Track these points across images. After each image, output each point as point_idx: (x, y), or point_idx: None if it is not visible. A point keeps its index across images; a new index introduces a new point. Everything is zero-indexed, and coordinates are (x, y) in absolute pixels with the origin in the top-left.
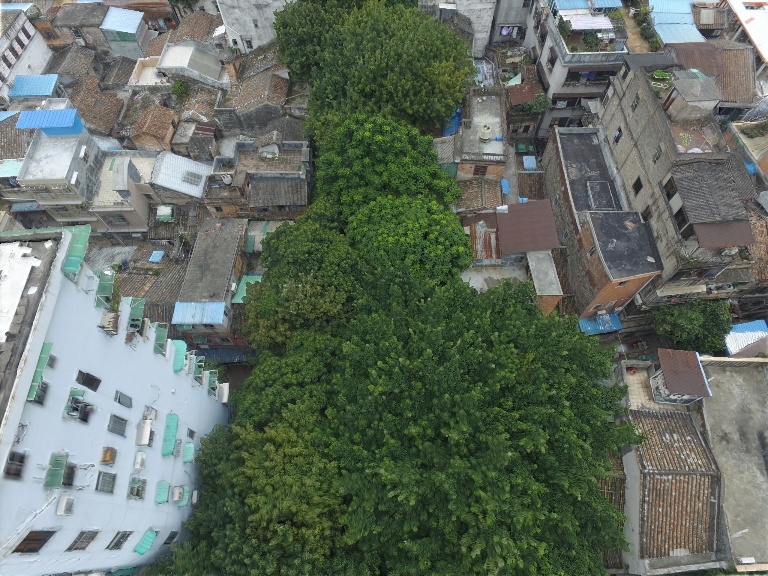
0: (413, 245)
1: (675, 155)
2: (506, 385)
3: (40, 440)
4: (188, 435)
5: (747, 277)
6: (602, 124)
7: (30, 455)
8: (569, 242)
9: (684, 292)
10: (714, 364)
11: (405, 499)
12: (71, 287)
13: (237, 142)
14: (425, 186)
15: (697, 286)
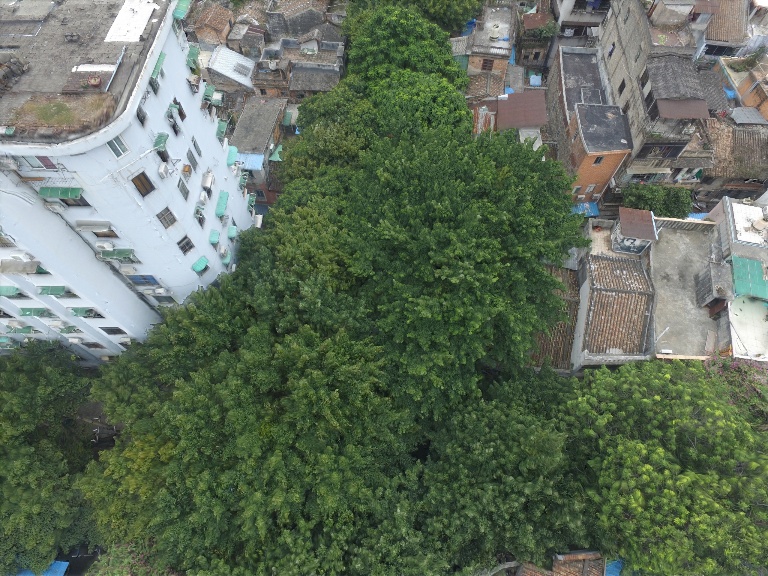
0: (423, 104)
1: (650, 48)
2: (484, 190)
3: (153, 116)
4: (232, 223)
5: (706, 164)
6: (601, 45)
7: (148, 119)
8: (560, 138)
9: (650, 172)
10: (667, 226)
11: (396, 241)
12: (175, 37)
13: (283, 39)
14: (439, 71)
15: (662, 169)
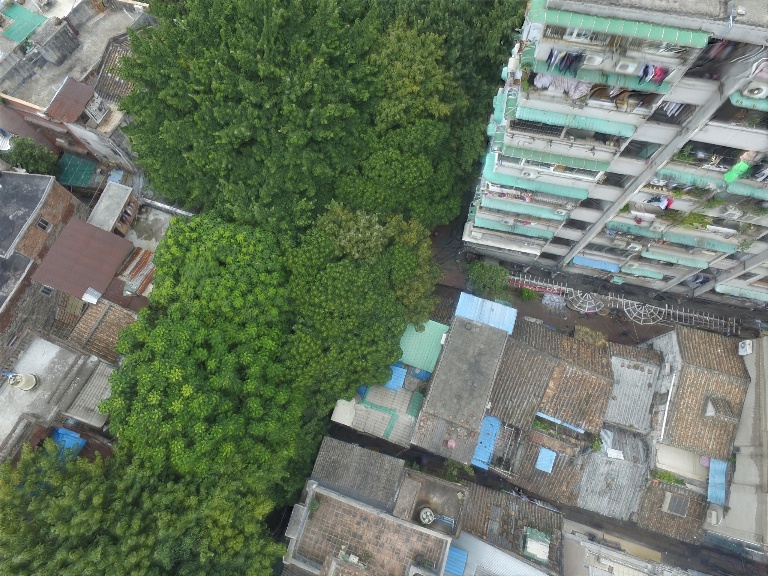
0: None
1: None
2: None
3: None
4: None
5: None
6: None
7: None
8: None
9: None
10: None
11: None
12: None
13: None
14: None
15: None
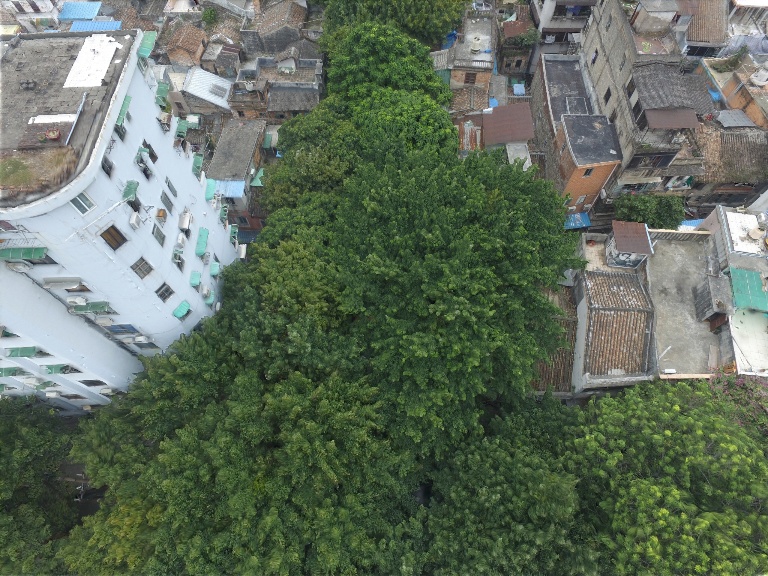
0: (407, 124)
1: (635, 57)
2: (475, 215)
3: (121, 164)
4: (214, 259)
5: (697, 171)
6: (583, 52)
7: (115, 169)
8: (547, 149)
9: (641, 182)
10: (661, 237)
11: (387, 276)
12: (141, 76)
13: (259, 58)
14: (421, 87)
15: (653, 178)
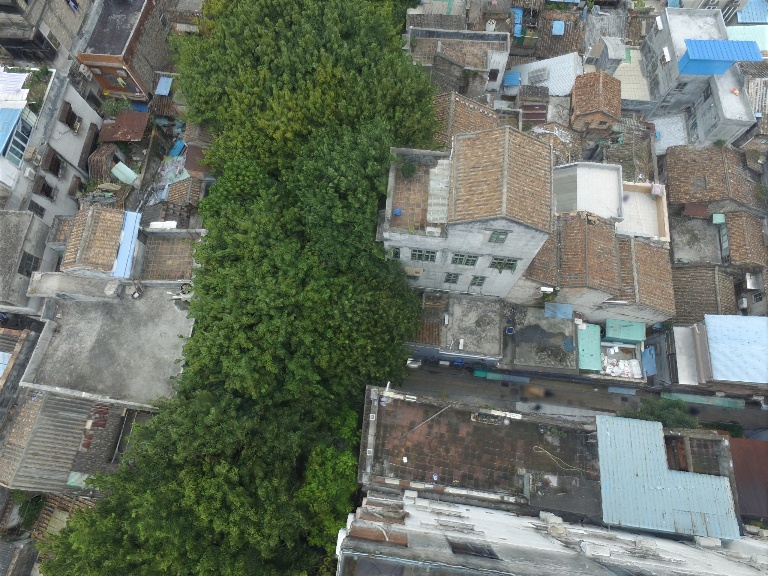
0: None
1: None
2: None
3: None
4: None
5: None
6: None
7: None
8: None
9: None
10: None
11: None
12: None
13: (486, 69)
14: None
15: None
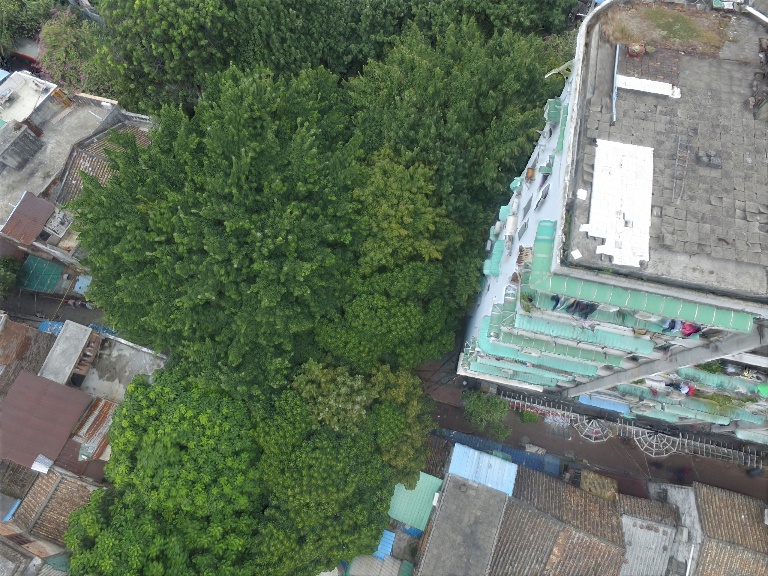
0: None
1: None
2: None
3: None
4: None
5: None
6: None
7: None
8: None
9: None
10: None
11: None
12: None
13: None
14: None
15: None
